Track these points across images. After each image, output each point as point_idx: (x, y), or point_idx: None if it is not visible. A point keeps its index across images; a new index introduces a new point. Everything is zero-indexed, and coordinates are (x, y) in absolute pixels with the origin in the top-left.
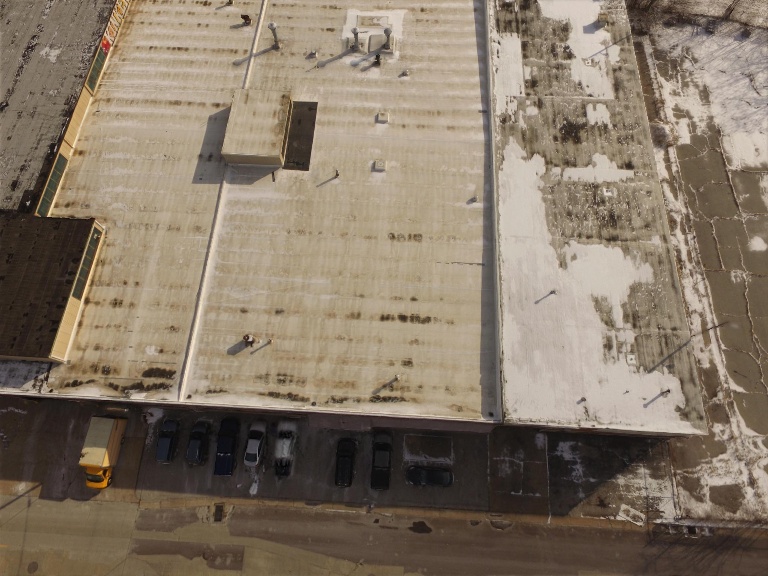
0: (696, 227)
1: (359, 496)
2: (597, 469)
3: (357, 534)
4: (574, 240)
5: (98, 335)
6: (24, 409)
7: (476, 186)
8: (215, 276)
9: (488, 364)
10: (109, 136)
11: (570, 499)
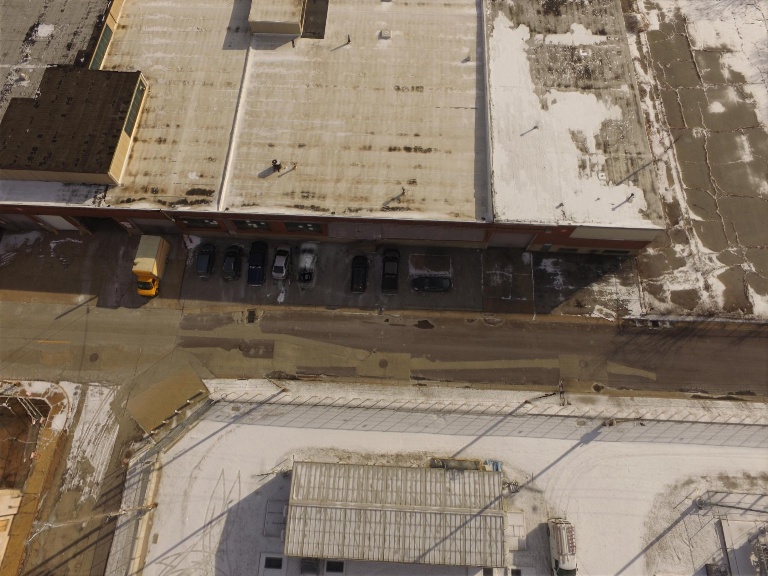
0: (663, 95)
1: (371, 302)
2: (575, 279)
3: (370, 330)
4: (554, 89)
5: (146, 165)
6: (80, 239)
7: (470, 49)
8: (245, 120)
9: (481, 182)
10: (148, 14)
11: (552, 302)
